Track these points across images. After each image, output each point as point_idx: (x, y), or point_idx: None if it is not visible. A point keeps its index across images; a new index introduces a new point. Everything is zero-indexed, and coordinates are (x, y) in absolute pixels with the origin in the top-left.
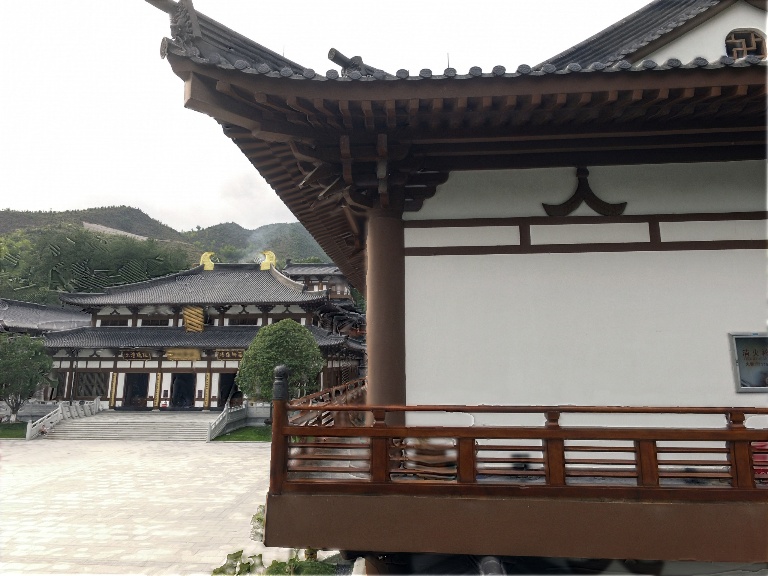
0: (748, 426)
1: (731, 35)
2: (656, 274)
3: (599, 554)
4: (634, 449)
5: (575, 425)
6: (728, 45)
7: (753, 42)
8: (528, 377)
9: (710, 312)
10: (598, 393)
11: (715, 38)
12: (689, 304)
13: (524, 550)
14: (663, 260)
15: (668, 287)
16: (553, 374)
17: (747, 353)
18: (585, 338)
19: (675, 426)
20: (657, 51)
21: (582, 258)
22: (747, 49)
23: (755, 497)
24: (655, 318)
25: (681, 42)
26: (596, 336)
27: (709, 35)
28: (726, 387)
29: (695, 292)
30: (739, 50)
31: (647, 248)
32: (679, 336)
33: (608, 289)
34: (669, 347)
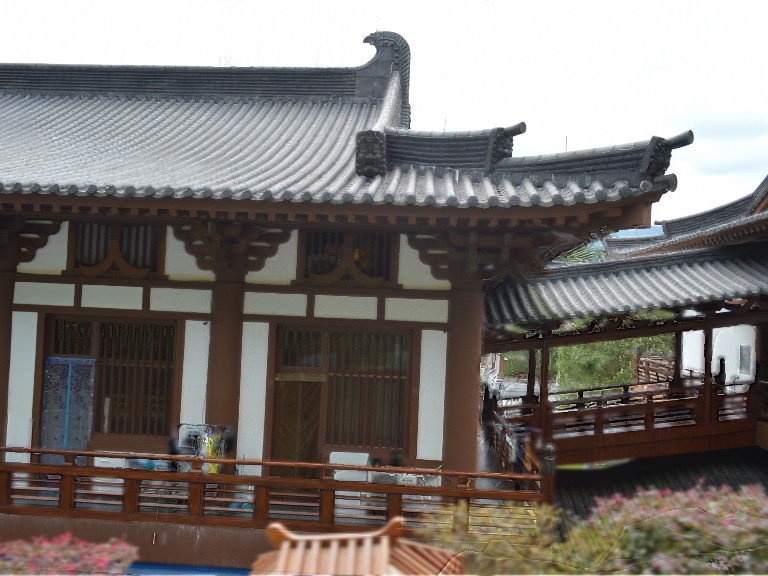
0: None
1: None
2: None
3: None
4: None
5: None
6: None
7: None
8: None
9: None
10: None
11: None
12: None
13: None
14: None
15: None
16: None
17: None
18: None
19: None
20: None
21: None
22: None
23: None
24: None
25: None
26: None
27: None
28: None
29: None
30: None
31: None
32: None
33: None
34: None
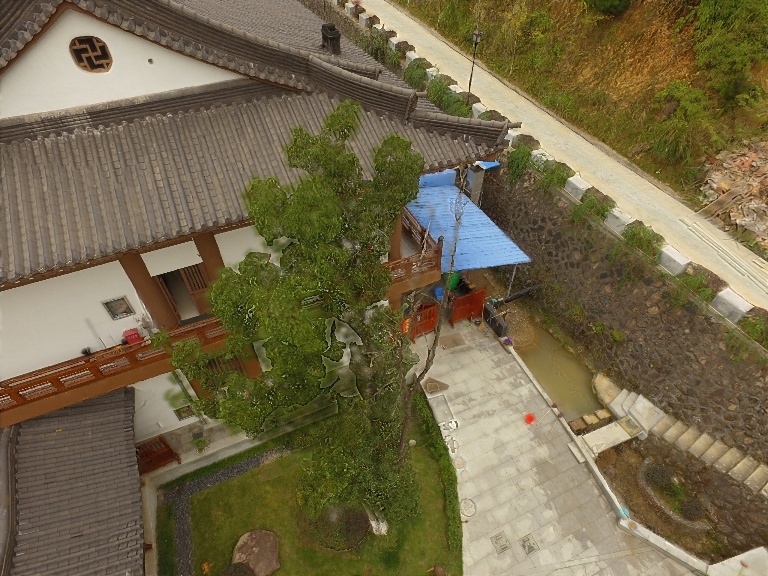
0: (123, 329)
1: (74, 41)
2: (50, 290)
3: (50, 411)
4: (49, 382)
5: (20, 383)
6: (75, 51)
7: (97, 47)
8: (3, 347)
9: (88, 296)
10: (45, 341)
11: (59, 50)
12: (75, 296)
13: (19, 421)
14: (51, 283)
15: (60, 293)
16: (16, 342)
17: (112, 307)
18: (25, 325)
19: (65, 369)
20: (8, 69)
21: (0, 295)
22: (93, 55)
23: (103, 378)
24: (60, 306)
25: (27, 59)
26: (31, 322)
27: (52, 47)
28: (108, 319)
29: (76, 291)
30: (87, 56)
31: (38, 280)
32: (76, 309)
33: (25, 303)
34: (73, 315)
